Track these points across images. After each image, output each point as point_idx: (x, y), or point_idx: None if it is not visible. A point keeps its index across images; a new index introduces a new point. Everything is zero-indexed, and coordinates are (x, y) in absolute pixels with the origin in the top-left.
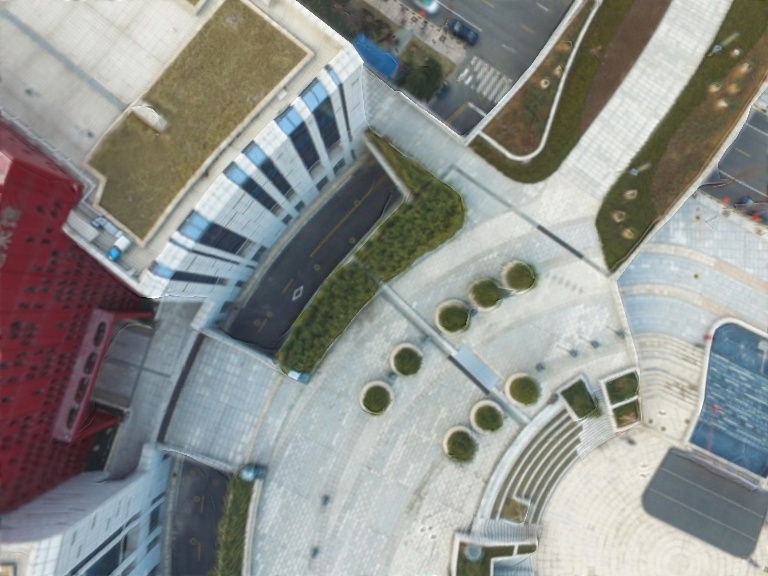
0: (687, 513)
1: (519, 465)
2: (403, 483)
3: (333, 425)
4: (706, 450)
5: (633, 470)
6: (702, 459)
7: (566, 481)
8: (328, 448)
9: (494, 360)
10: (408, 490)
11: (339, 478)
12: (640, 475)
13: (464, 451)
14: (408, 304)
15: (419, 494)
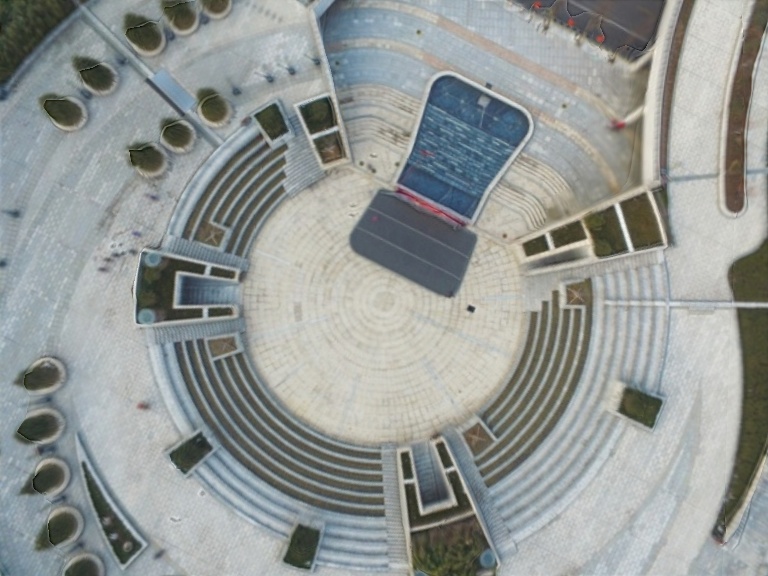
0: (392, 251)
1: (214, 188)
2: (95, 200)
3: (27, 142)
4: (413, 190)
5: (342, 210)
6: (405, 195)
7: (275, 219)
8: (21, 164)
9: (191, 84)
10: (100, 207)
11: (30, 194)
12: (349, 215)
13: (143, 157)
14: (106, 26)
15: (111, 211)
